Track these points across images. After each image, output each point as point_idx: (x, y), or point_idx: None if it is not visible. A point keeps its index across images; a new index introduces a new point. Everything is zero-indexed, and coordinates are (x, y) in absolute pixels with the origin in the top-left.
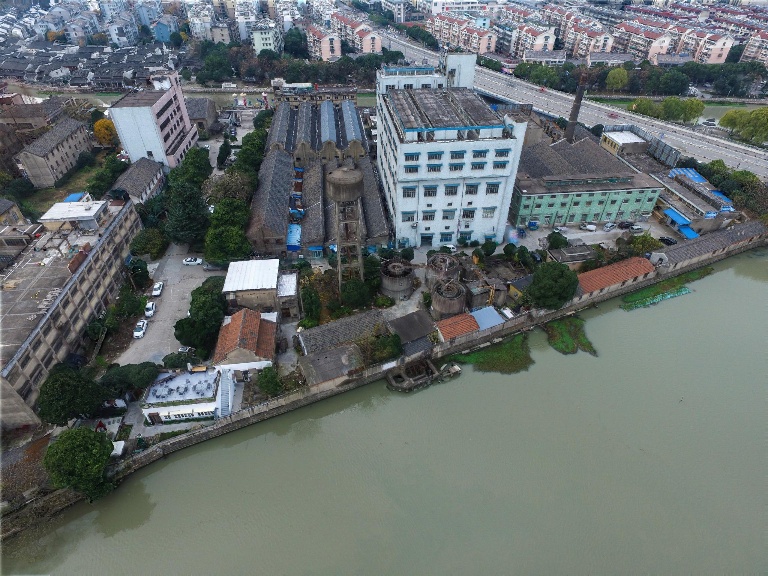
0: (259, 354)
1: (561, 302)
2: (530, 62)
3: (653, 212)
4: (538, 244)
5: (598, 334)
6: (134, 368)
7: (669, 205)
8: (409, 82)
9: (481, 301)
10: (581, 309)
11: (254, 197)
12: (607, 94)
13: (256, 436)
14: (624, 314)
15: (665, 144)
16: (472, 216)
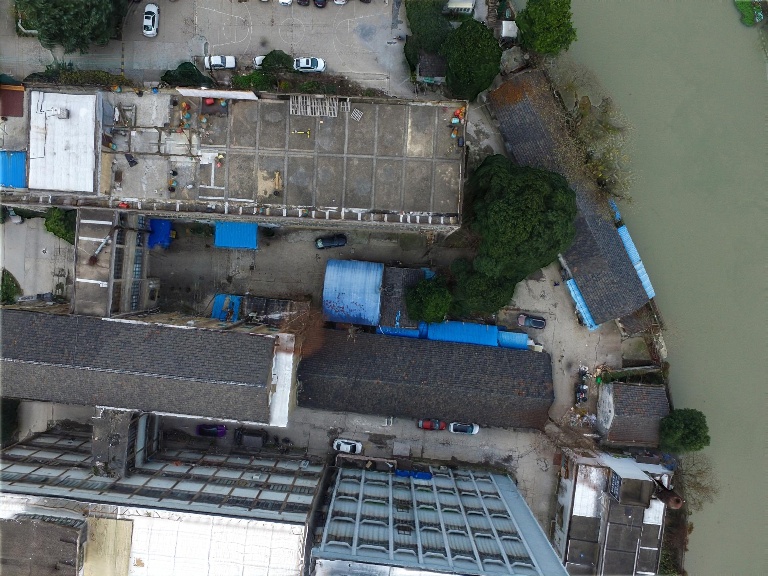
0: None
1: None
2: None
3: None
4: None
5: None
6: None
7: None
8: None
9: None
10: None
11: None
12: None
13: None
14: None
15: None
16: None
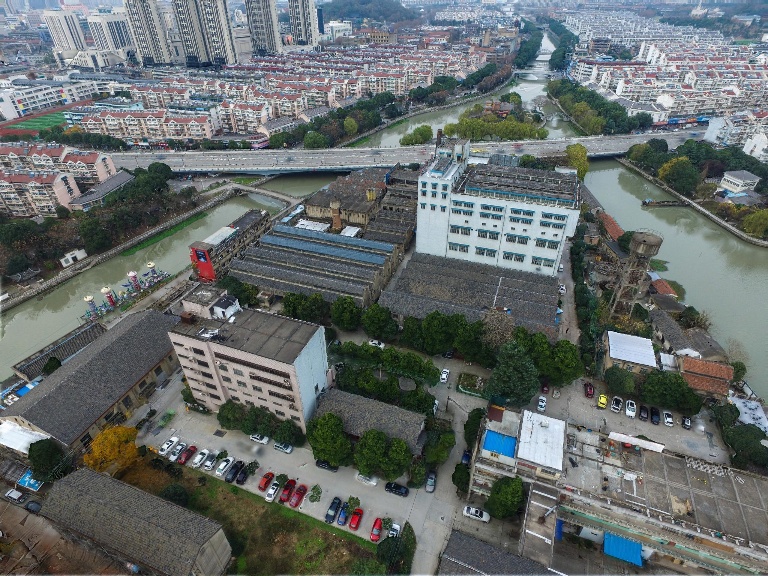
0: None
1: None
2: (272, 133)
3: None
4: None
5: None
6: (751, 434)
7: None
8: (456, 175)
9: None
10: None
11: None
12: (349, 139)
13: None
14: None
15: (505, 155)
16: None
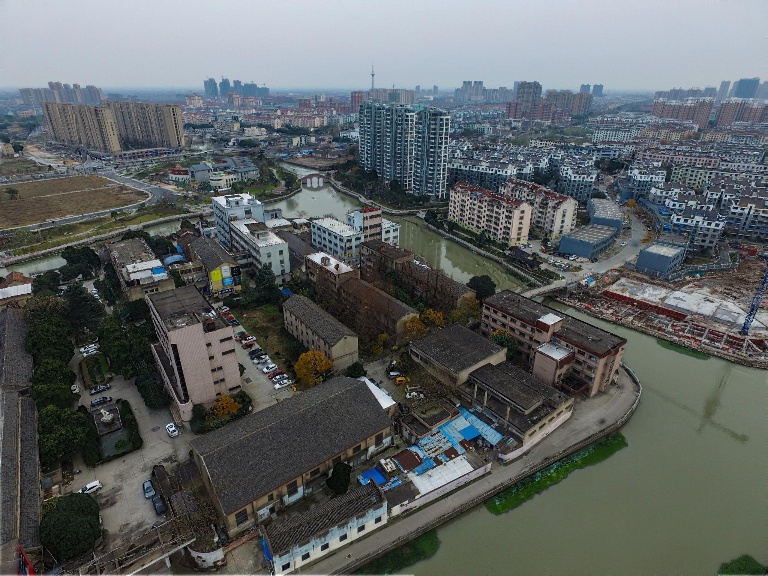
0: None
1: None
2: None
3: None
4: None
5: None
6: (69, 267)
7: None
8: None
9: None
10: None
11: None
12: None
13: None
14: None
15: None
16: None
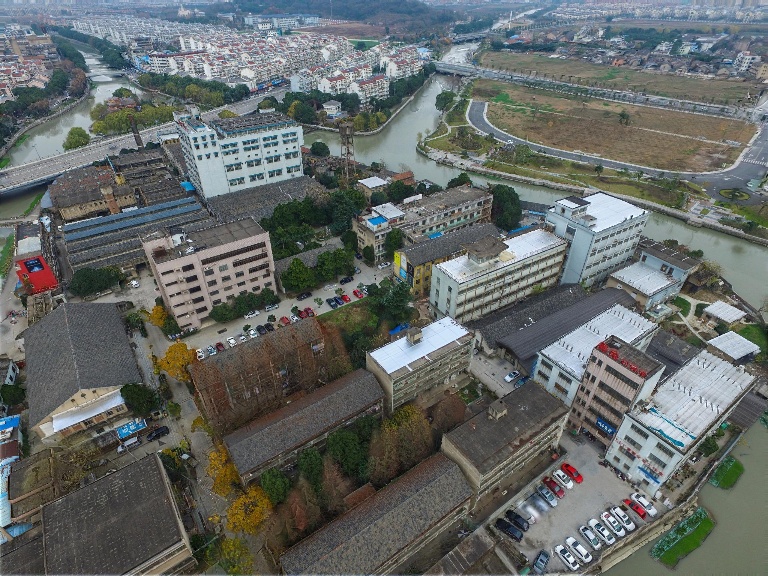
0: None
1: None
2: None
3: None
4: None
5: None
6: (434, 188)
7: None
8: None
9: None
10: None
11: None
12: None
13: None
14: None
15: None
16: None
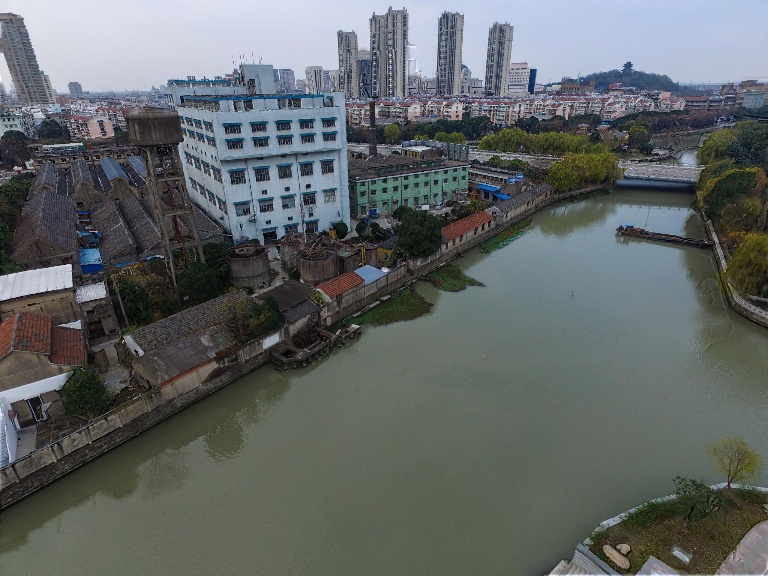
0: (58, 361)
1: (433, 245)
2: None
3: (467, 194)
4: (386, 225)
5: (476, 272)
6: None
7: (478, 182)
8: (207, 92)
9: (354, 265)
10: (450, 260)
11: (17, 230)
12: None
13: (75, 503)
14: (487, 256)
15: None
16: (314, 202)
